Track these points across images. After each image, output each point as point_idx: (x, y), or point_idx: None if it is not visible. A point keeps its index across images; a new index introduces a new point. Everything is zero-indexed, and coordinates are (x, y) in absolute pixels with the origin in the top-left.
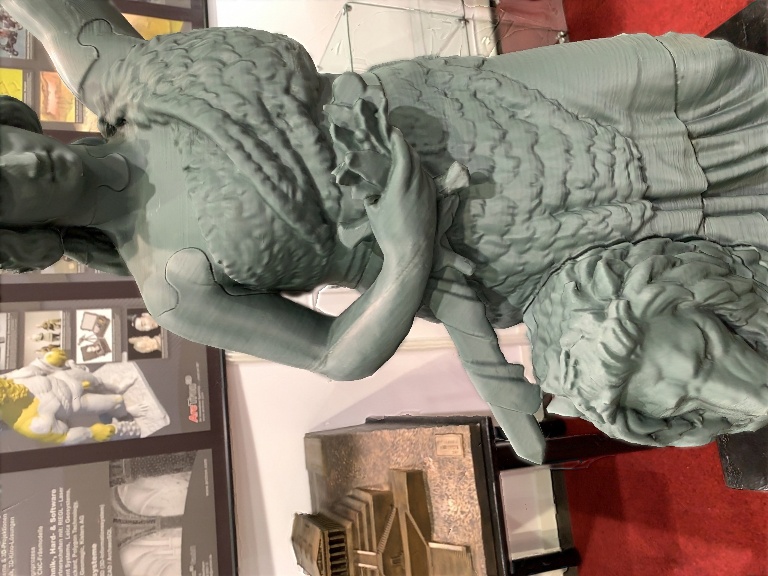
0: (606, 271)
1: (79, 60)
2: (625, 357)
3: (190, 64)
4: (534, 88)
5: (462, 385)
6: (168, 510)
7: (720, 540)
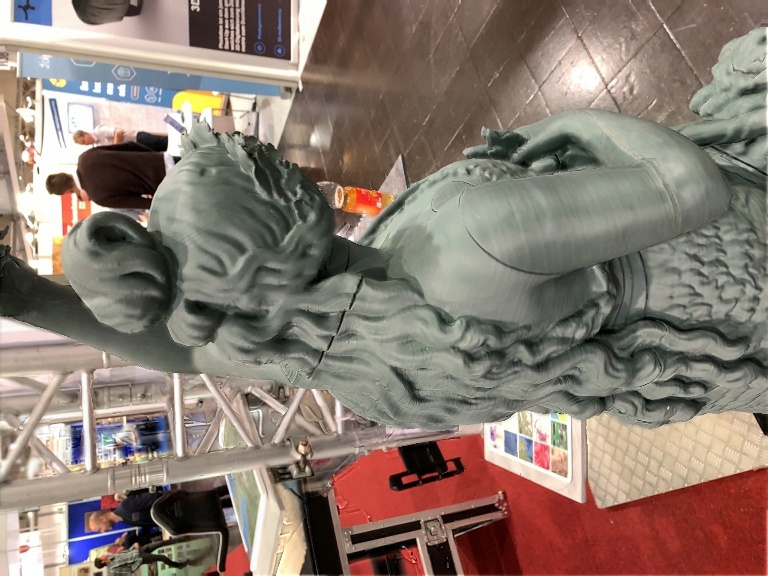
0: None
1: None
2: None
3: None
4: None
5: None
6: None
7: None
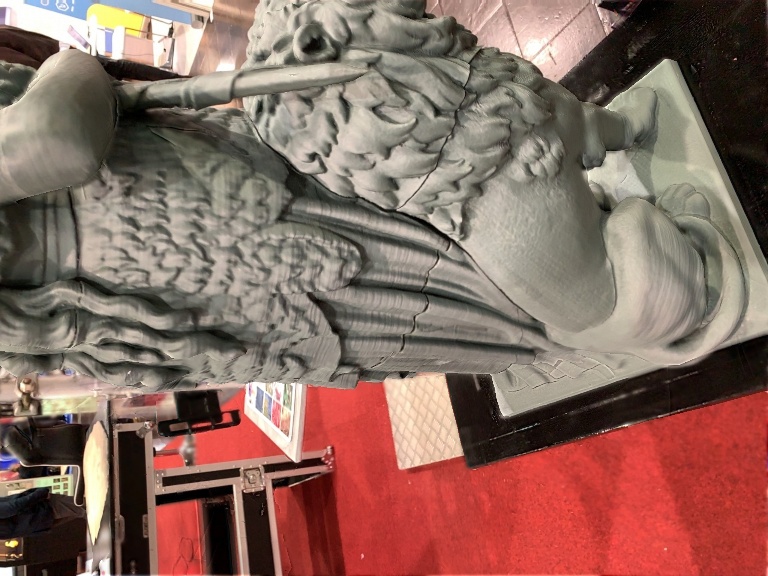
0: None
1: None
2: None
3: None
4: None
5: None
6: None
7: None
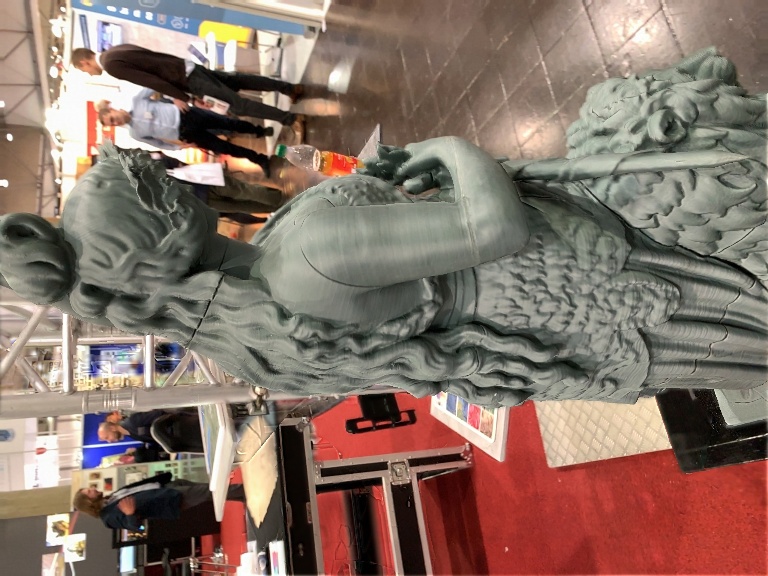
0: None
1: None
2: None
3: None
4: None
5: None
6: None
7: None
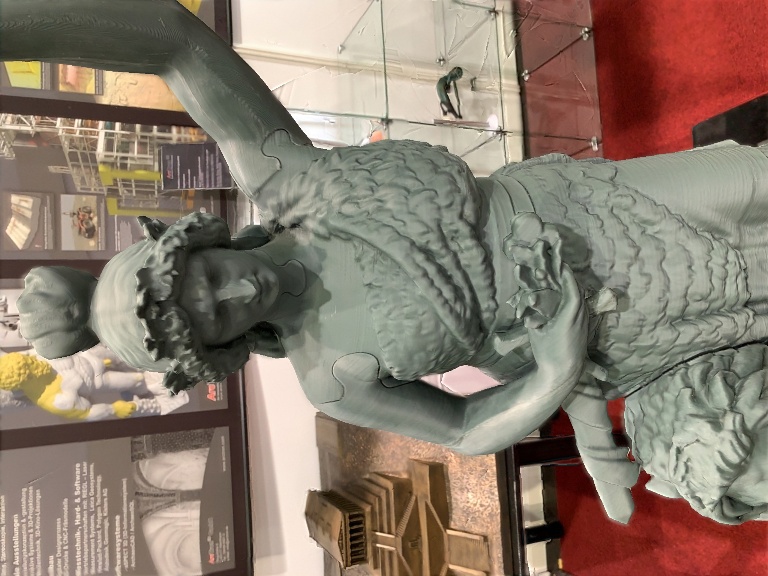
0: (724, 386)
1: (261, 169)
2: (737, 464)
3: (375, 188)
4: (662, 203)
5: (464, 368)
6: (187, 484)
7: (701, 528)
